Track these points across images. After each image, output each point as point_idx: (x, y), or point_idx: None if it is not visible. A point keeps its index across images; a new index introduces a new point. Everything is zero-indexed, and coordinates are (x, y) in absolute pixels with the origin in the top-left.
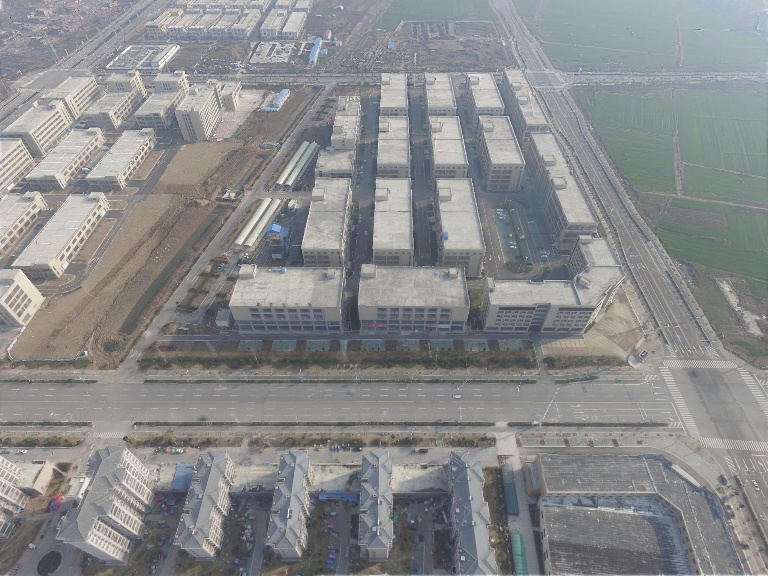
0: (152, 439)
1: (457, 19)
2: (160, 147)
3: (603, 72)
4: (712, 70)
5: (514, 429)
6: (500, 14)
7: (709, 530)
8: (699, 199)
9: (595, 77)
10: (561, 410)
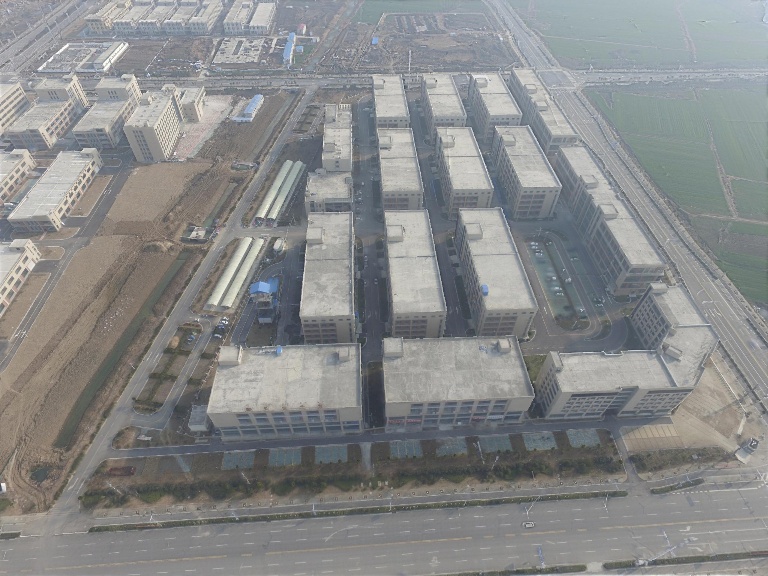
0: None
1: (445, 11)
2: (107, 171)
3: (615, 70)
4: (731, 66)
5: (613, 574)
6: (491, 5)
7: None
8: (759, 222)
9: (608, 75)
10: (668, 537)
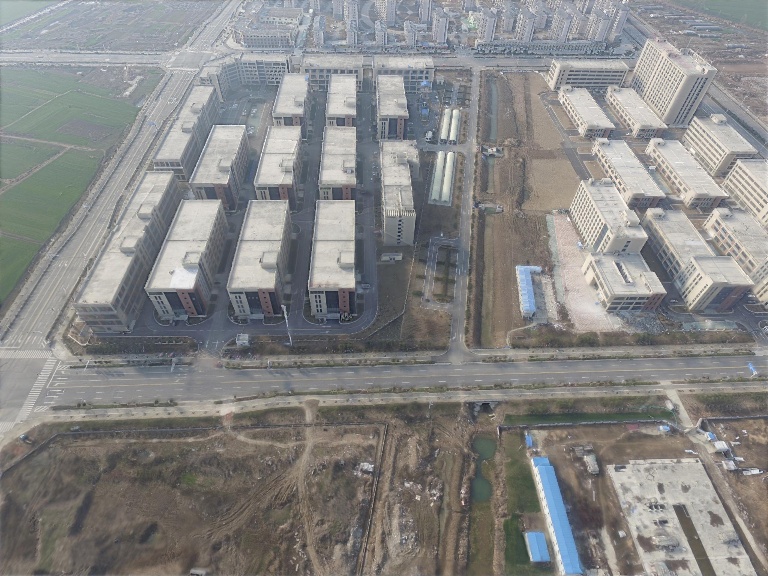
0: None
1: None
2: None
3: None
4: None
5: None
6: None
7: None
8: (57, 143)
9: None
10: None
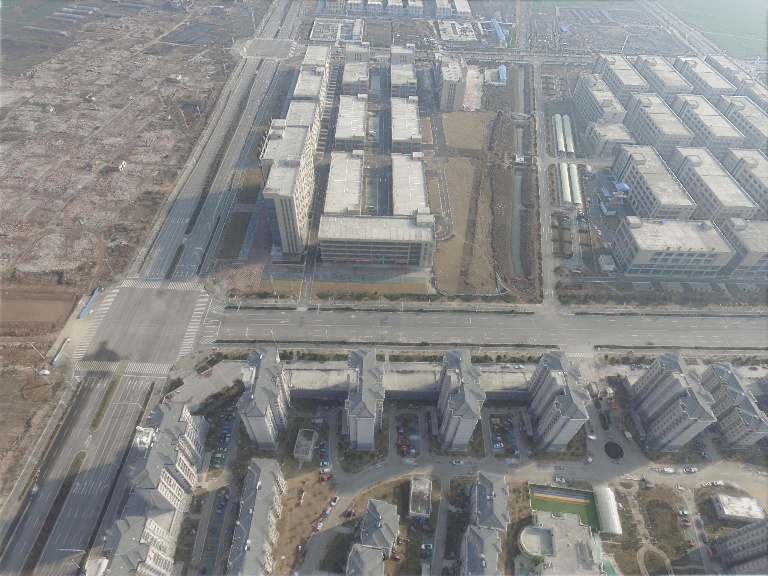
0: (620, 359)
1: (607, 6)
2: (423, 115)
3: None
4: None
5: None
6: (645, 3)
7: None
8: None
9: None
10: None
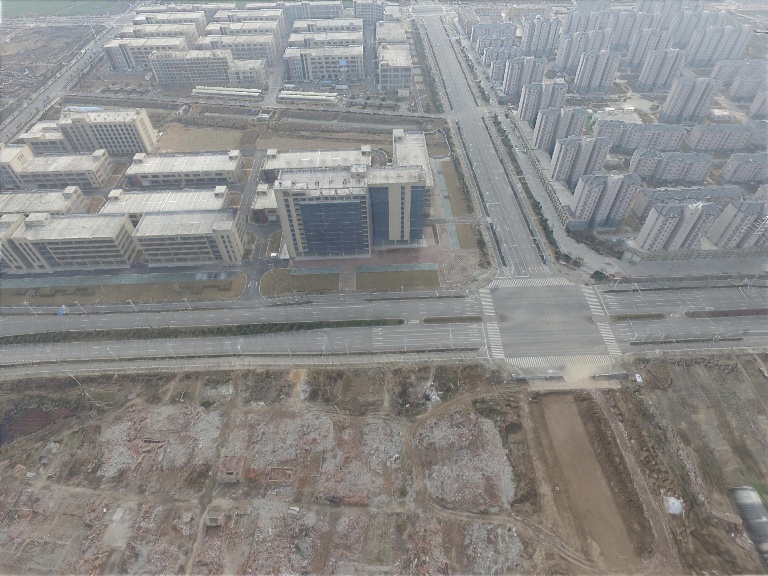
0: None
1: None
2: None
3: None
4: None
5: None
6: None
7: (482, 6)
8: None
9: None
10: None
